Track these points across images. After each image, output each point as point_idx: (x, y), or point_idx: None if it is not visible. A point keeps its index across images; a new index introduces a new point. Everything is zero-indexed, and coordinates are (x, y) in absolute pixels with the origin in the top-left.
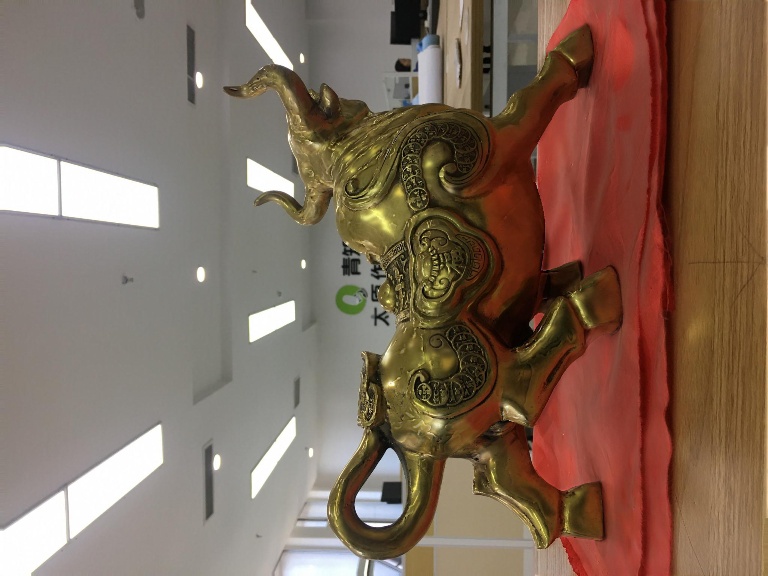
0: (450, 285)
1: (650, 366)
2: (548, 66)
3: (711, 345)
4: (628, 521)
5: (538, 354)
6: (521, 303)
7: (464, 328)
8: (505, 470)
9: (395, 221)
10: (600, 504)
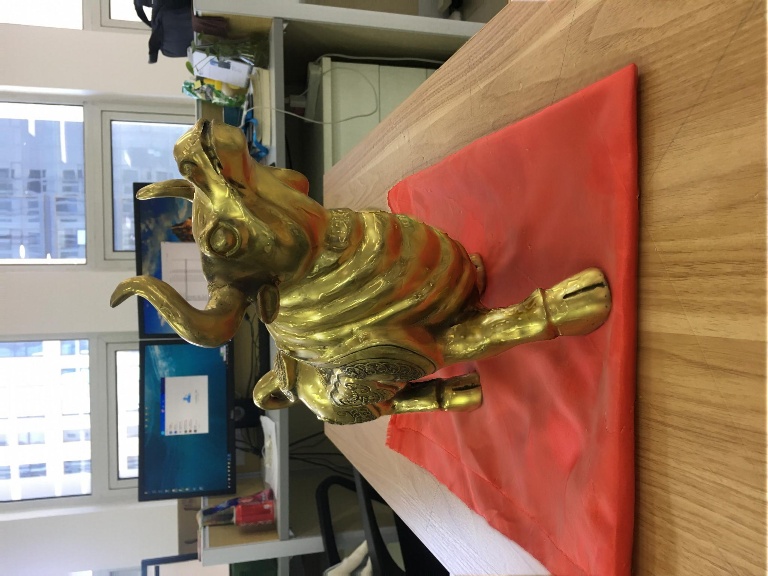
0: None
1: None
2: (533, 335)
3: None
4: None
5: None
6: None
7: None
8: None
9: None
10: None
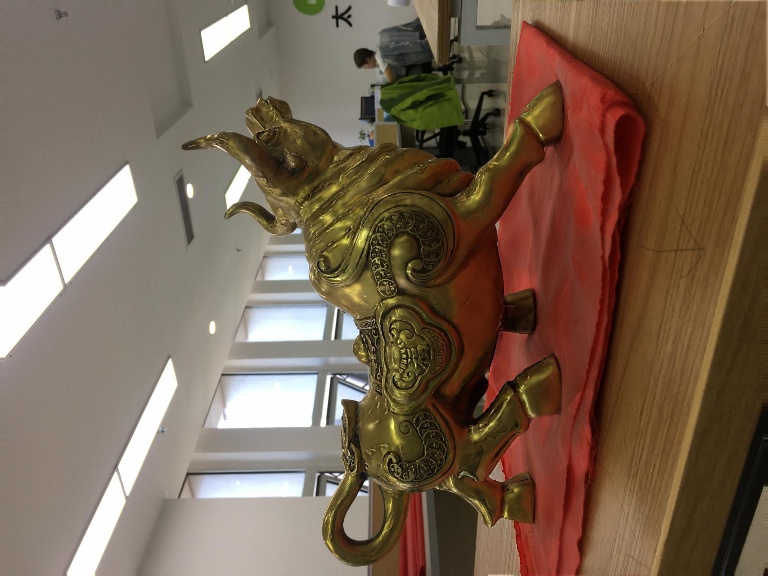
0: (417, 379)
1: (574, 482)
2: (516, 141)
3: (611, 550)
4: (549, 544)
5: (489, 437)
6: (478, 375)
7: (428, 415)
8: (460, 479)
9: (366, 301)
10: (533, 499)
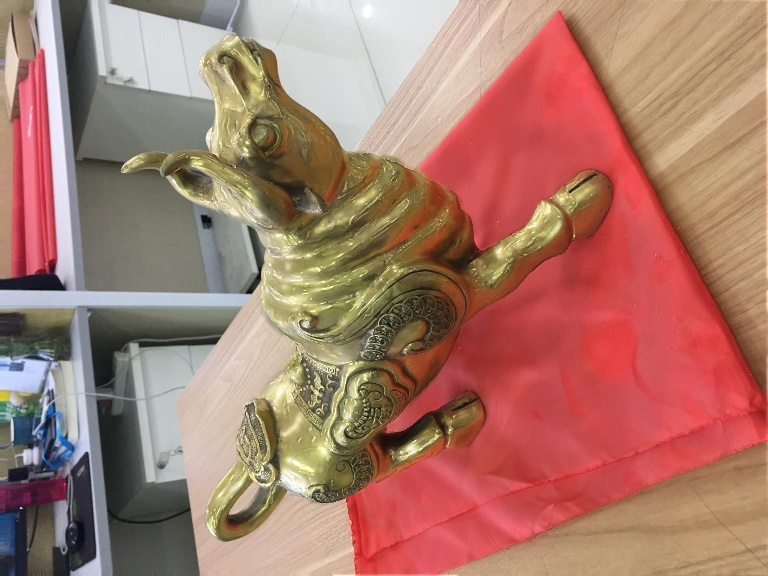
0: (370, 431)
1: (474, 511)
2: (553, 238)
3: None
4: (401, 504)
5: (406, 463)
6: None
7: (365, 454)
8: None
9: (339, 356)
10: None
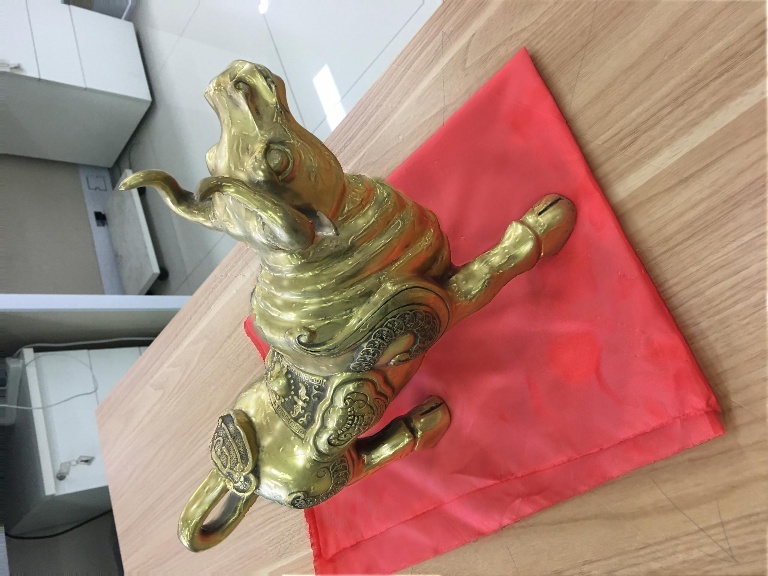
0: (351, 438)
1: (439, 508)
2: (525, 256)
3: None
4: (361, 505)
5: (377, 466)
6: None
7: None
8: None
9: (328, 368)
10: None
